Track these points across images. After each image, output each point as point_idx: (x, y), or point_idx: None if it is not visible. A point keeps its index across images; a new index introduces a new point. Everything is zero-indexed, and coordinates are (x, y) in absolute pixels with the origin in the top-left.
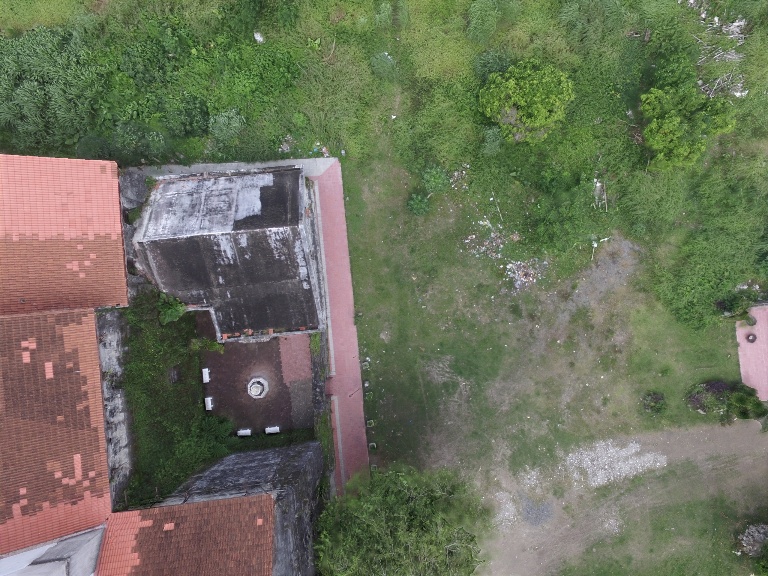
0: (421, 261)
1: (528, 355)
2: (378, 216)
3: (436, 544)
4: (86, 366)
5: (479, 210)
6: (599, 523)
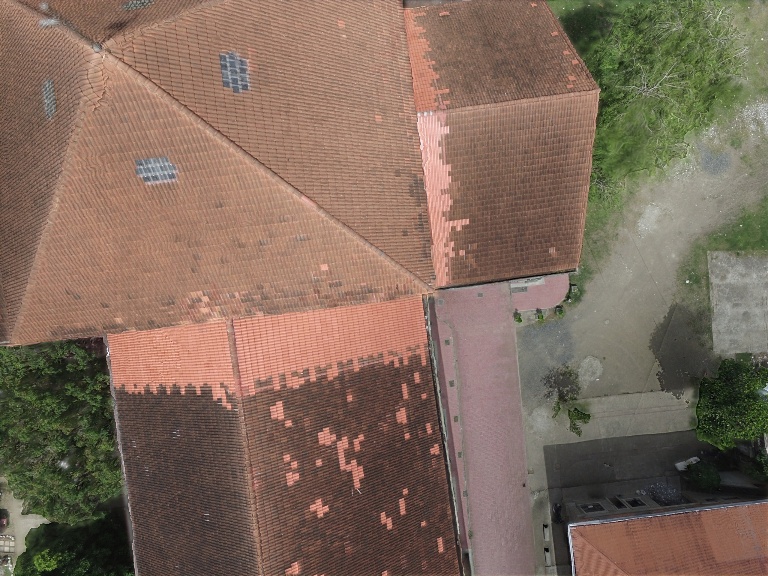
0: None
1: None
2: None
3: (715, 5)
4: None
5: None
6: None
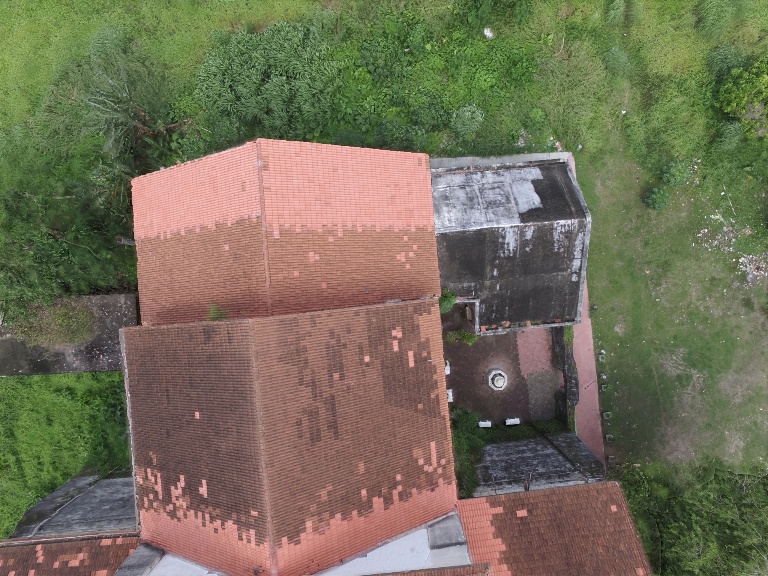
0: (654, 255)
1: (760, 348)
2: (611, 210)
3: None
4: (435, 355)
5: (711, 204)
6: None
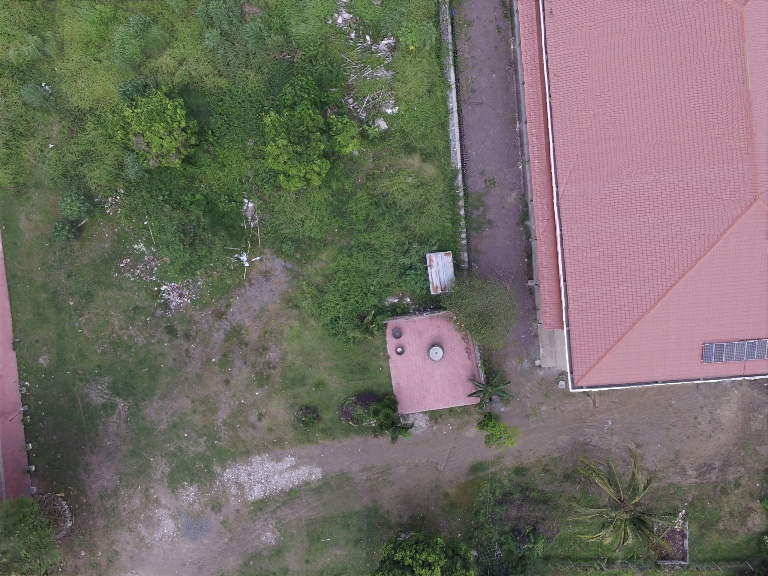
0: (77, 286)
1: (184, 374)
2: (35, 243)
3: None
4: None
5: (134, 234)
6: (256, 536)
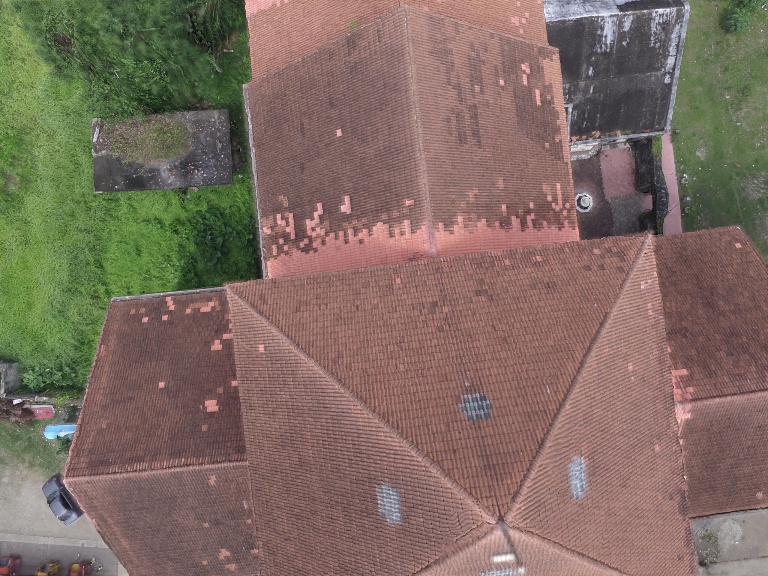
0: (734, 80)
1: None
2: (690, 37)
3: None
4: (557, 102)
5: None
6: None
